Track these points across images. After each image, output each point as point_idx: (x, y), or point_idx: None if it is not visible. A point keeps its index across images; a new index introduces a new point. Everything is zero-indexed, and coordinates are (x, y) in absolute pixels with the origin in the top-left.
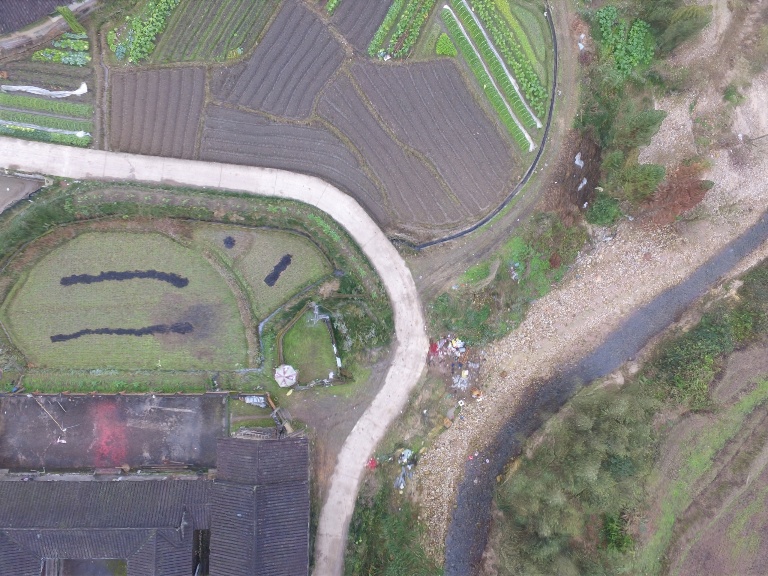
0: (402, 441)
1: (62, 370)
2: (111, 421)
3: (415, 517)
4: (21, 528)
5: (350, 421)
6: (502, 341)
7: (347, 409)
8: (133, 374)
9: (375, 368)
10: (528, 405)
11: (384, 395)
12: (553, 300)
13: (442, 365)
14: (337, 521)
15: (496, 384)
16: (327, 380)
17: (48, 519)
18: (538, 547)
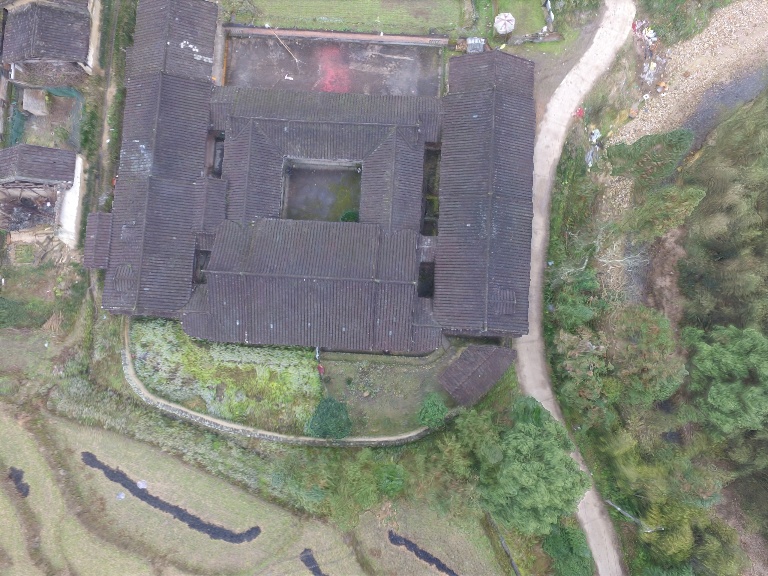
0: (605, 100)
1: (290, 17)
2: (335, 63)
3: (600, 196)
4: (272, 118)
5: (559, 75)
6: (686, 43)
7: (556, 64)
8: (356, 24)
9: (583, 29)
10: (708, 106)
11: (592, 53)
12: (736, 9)
13: (639, 44)
14: (545, 163)
15: (679, 83)
16: (541, 32)
17: (295, 114)
18: (754, 166)
